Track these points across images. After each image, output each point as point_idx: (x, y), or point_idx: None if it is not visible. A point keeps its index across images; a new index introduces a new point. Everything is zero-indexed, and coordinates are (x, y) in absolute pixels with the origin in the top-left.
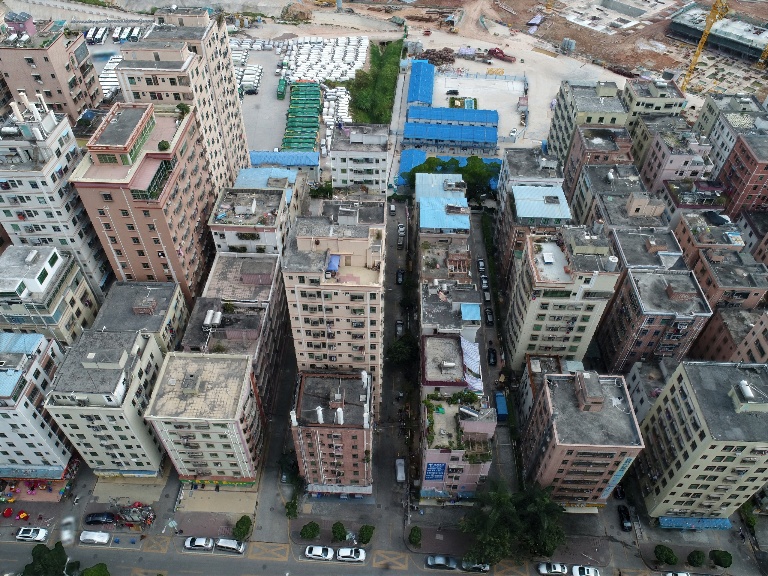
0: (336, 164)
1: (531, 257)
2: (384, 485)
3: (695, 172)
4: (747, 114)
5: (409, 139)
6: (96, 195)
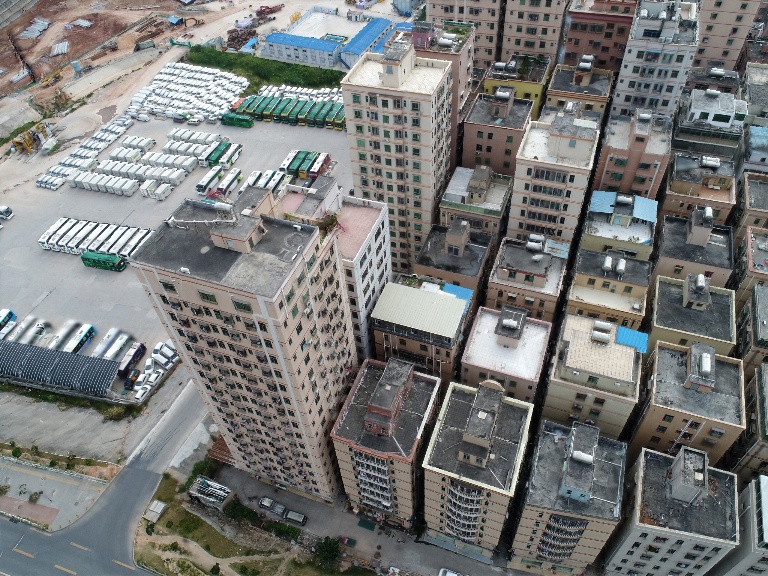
0: None
1: None
2: None
3: None
4: None
5: None
6: None
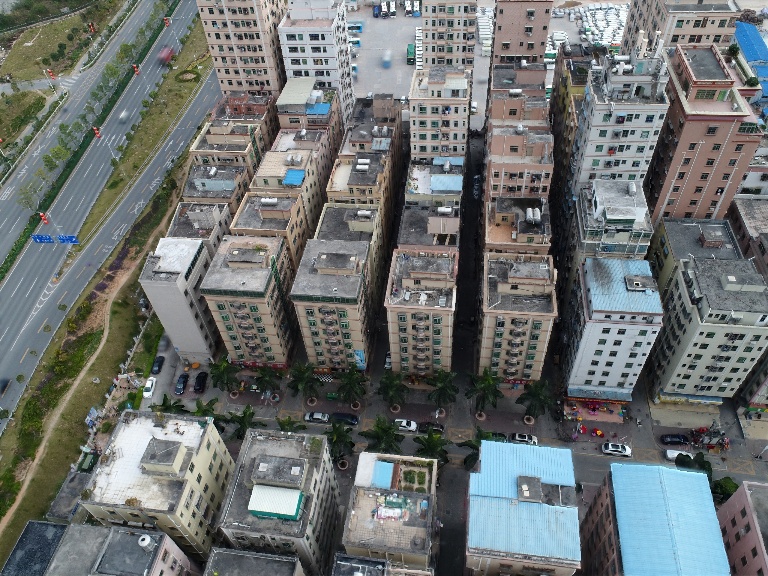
0: None
1: None
2: None
3: None
4: None
5: (767, 98)
6: (701, 129)
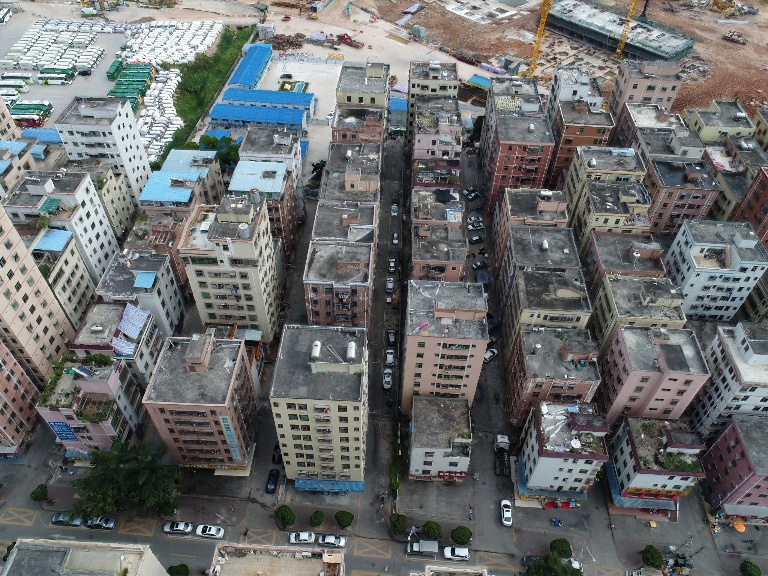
0: (65, 137)
1: (188, 225)
2: (43, 447)
3: (446, 152)
4: (518, 97)
5: (217, 120)
6: None
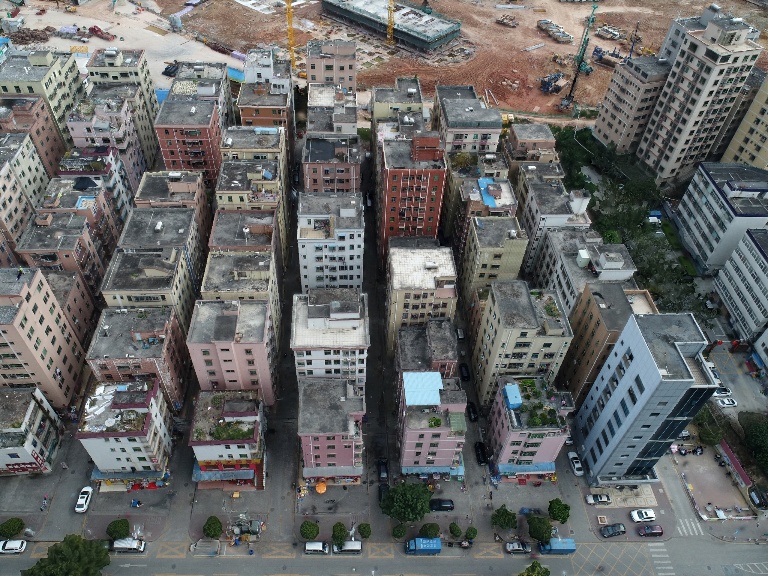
0: None
1: None
2: None
3: (106, 139)
4: (200, 81)
5: None
6: None
